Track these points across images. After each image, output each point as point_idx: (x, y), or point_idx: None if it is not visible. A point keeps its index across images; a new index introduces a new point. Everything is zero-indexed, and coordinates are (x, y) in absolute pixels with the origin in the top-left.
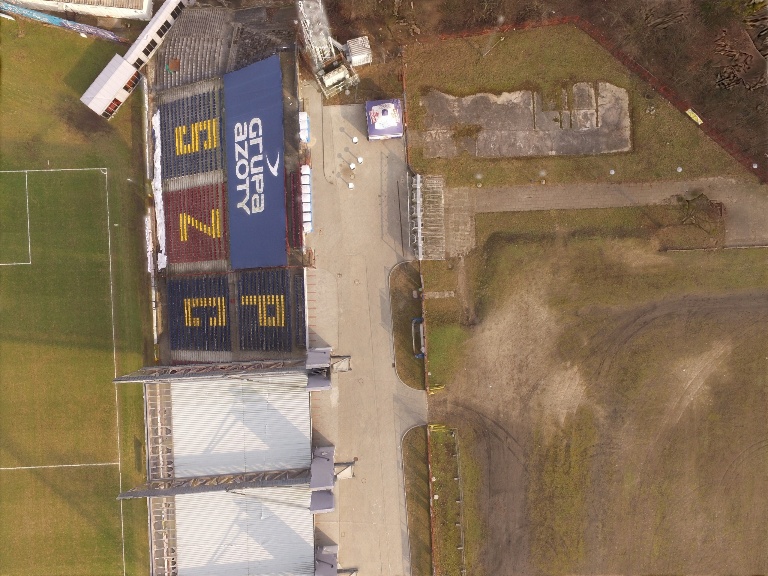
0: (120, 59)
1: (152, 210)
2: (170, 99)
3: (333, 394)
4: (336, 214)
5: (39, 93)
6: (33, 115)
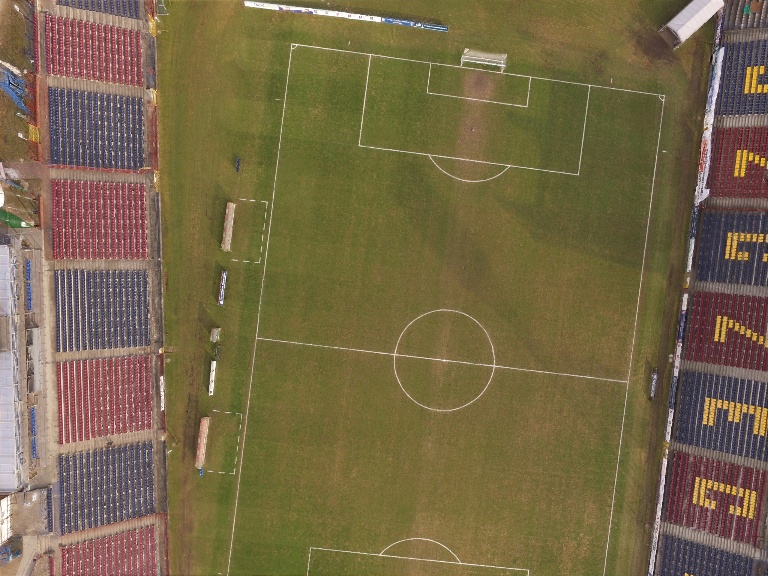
0: None
1: (700, 143)
2: (743, 39)
3: None
4: None
5: (613, 13)
6: (604, 33)
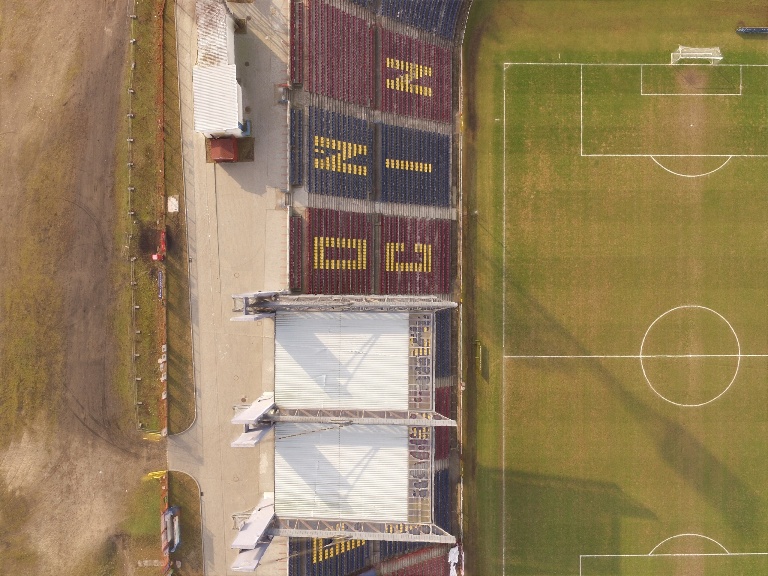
0: None
1: None
2: None
3: (265, 467)
4: None
5: None
6: None
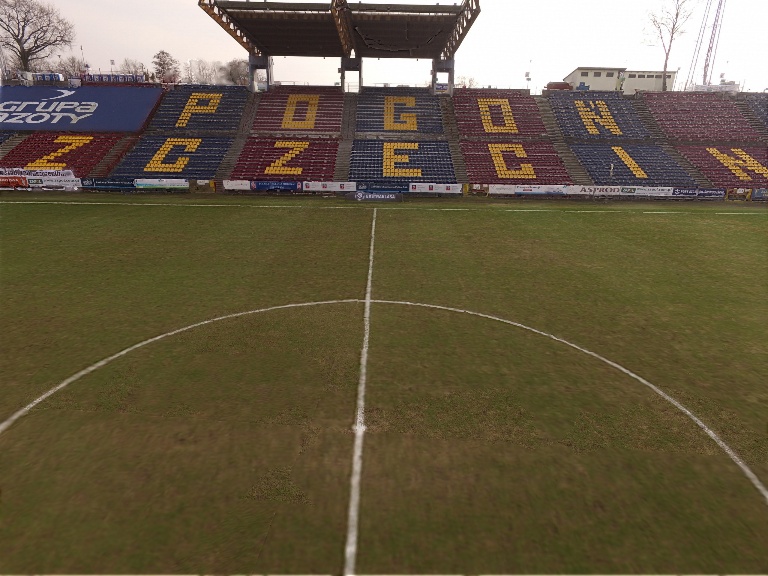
0: None
1: None
2: None
3: None
4: None
5: None
6: None
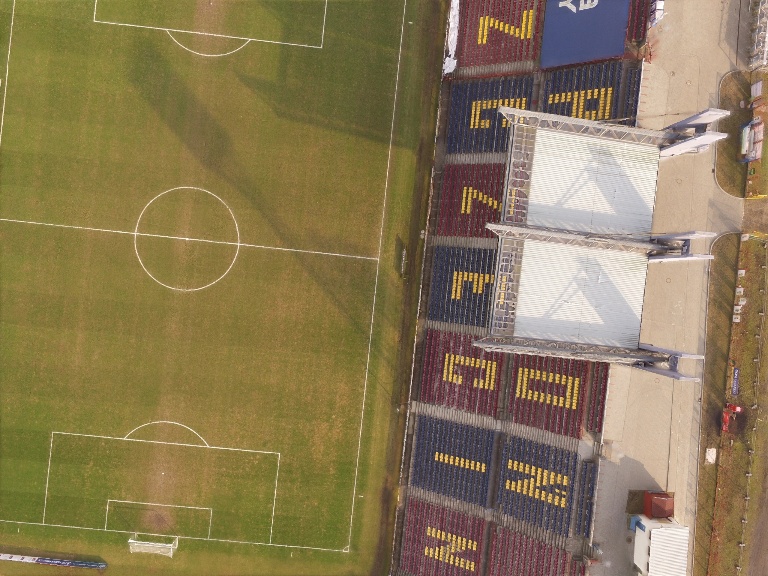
0: None
1: (448, 13)
2: None
3: None
4: (678, 13)
5: None
6: None
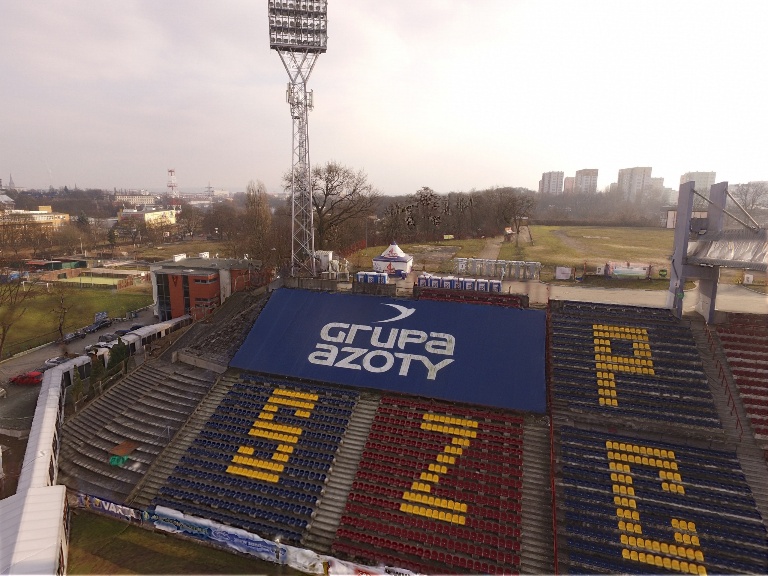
0: (14, 497)
1: None
2: (165, 473)
3: None
4: None
5: None
6: None
